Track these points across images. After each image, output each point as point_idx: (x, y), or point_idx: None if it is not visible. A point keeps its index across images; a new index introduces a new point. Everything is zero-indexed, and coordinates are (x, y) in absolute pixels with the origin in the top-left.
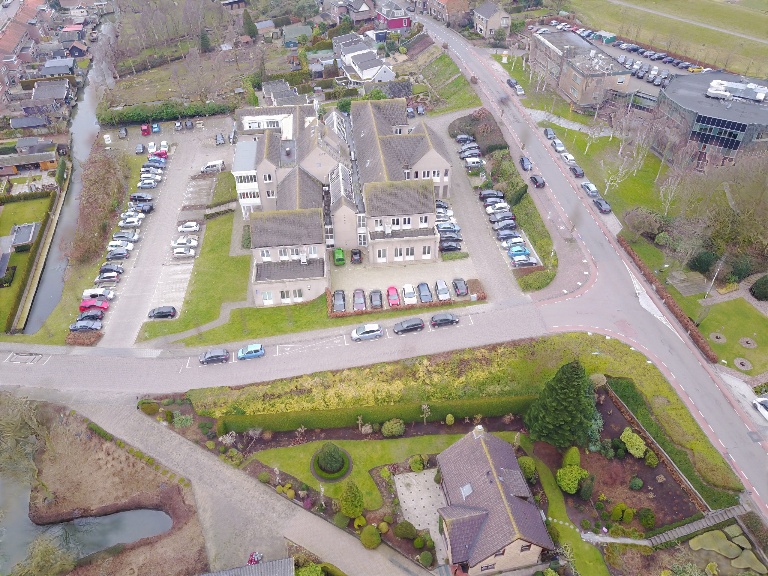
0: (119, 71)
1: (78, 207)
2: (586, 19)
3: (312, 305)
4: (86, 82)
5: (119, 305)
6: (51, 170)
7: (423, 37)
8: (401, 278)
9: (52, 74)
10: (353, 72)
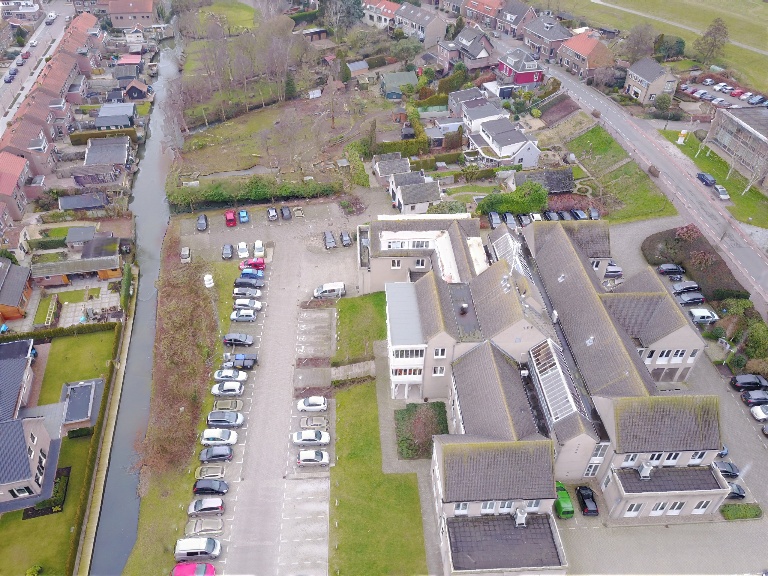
0: (188, 122)
1: (151, 347)
2: (744, 77)
3: None
4: (147, 134)
5: (229, 569)
6: (112, 280)
7: (563, 98)
8: (671, 556)
9: (108, 125)
10: (484, 144)
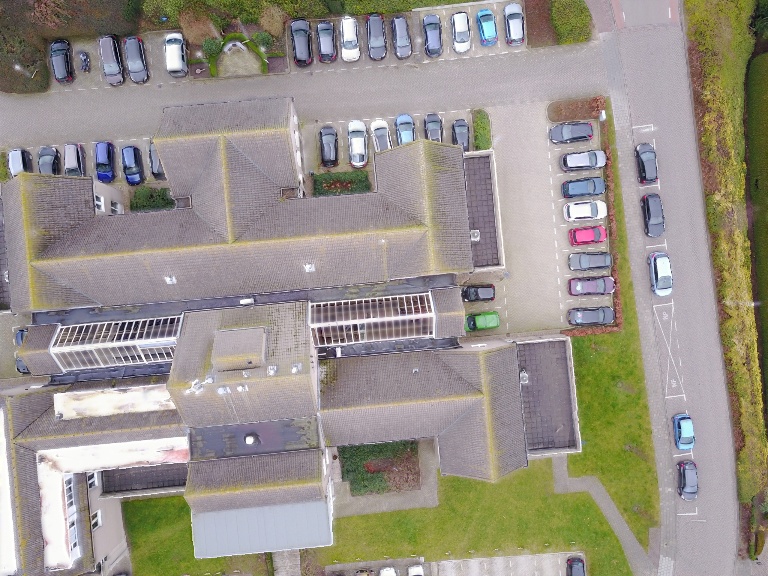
0: None
1: None
2: None
3: (575, 357)
4: None
5: None
6: None
7: None
8: (533, 222)
9: None
10: None
